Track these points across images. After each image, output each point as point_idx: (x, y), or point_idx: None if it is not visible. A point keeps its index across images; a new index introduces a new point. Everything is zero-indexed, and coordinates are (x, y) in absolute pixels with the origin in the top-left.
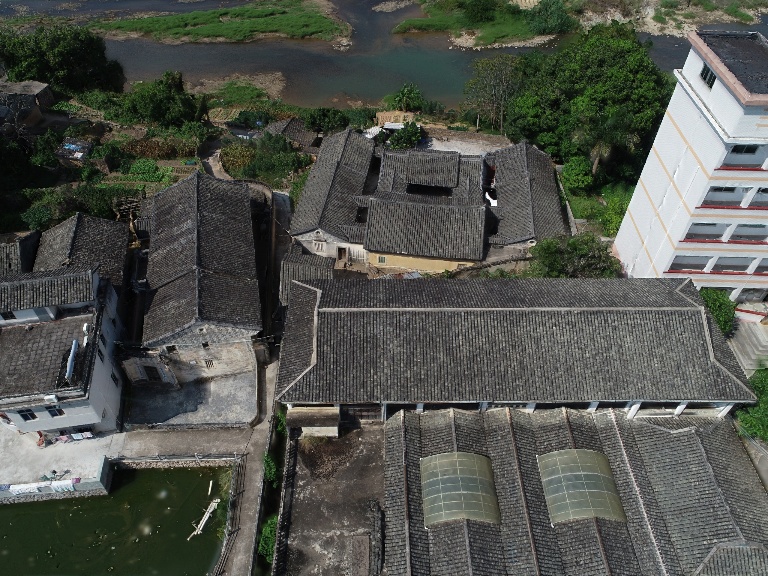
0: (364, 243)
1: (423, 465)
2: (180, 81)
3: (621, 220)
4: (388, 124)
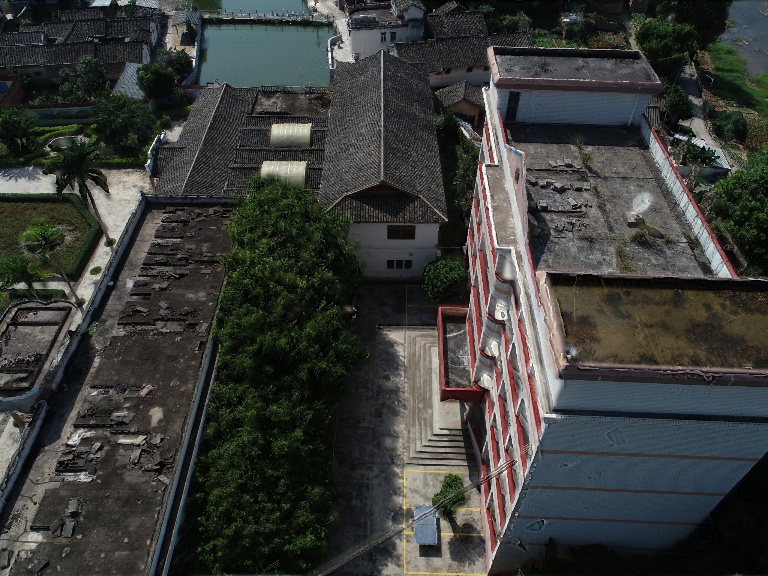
0: None
1: None
2: (685, 35)
3: None
4: (715, 148)
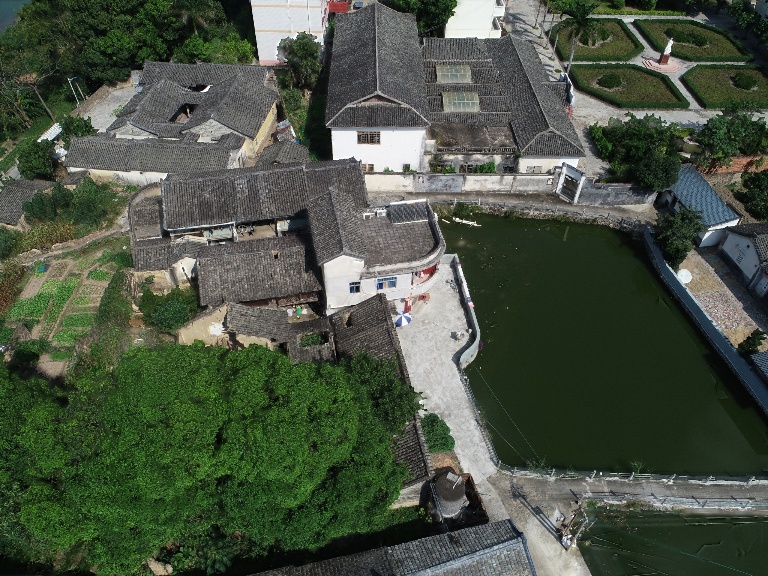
0: (250, 135)
1: (447, 109)
2: None
3: (250, 46)
4: None
